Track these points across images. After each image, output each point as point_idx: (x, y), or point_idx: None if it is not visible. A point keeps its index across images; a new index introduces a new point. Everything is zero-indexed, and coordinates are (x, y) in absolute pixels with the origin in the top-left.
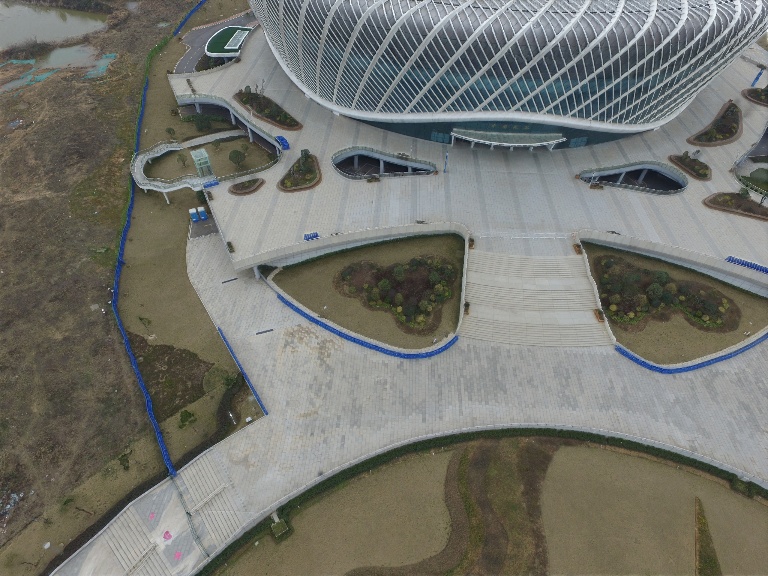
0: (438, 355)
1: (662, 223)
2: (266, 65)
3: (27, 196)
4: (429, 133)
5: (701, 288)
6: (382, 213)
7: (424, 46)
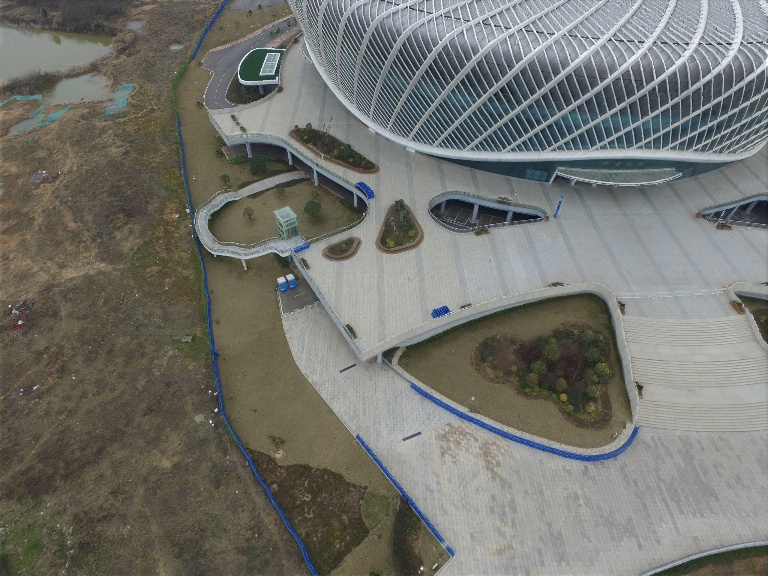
0: (623, 453)
1: None
2: (313, 94)
3: (78, 271)
4: (524, 171)
5: None
6: (507, 274)
7: (553, 85)
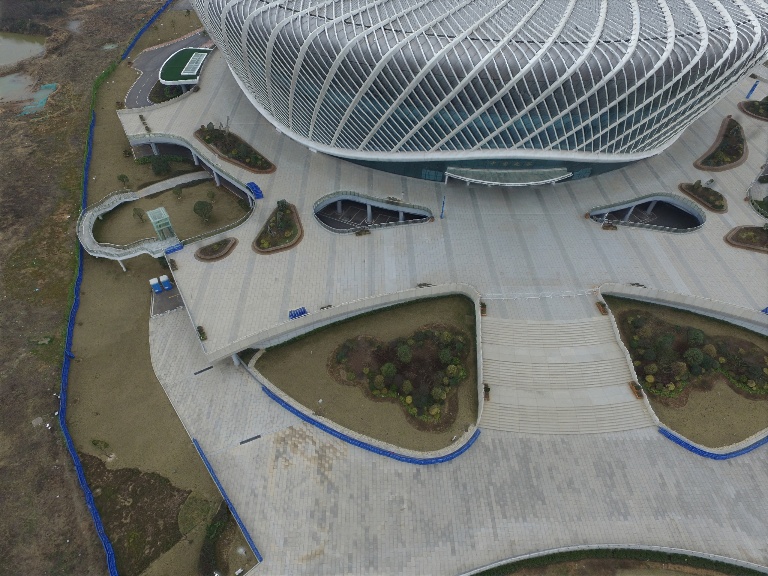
0: (460, 457)
1: (687, 268)
2: (229, 93)
3: None
4: (419, 171)
5: (739, 344)
6: (377, 275)
7: (416, 84)
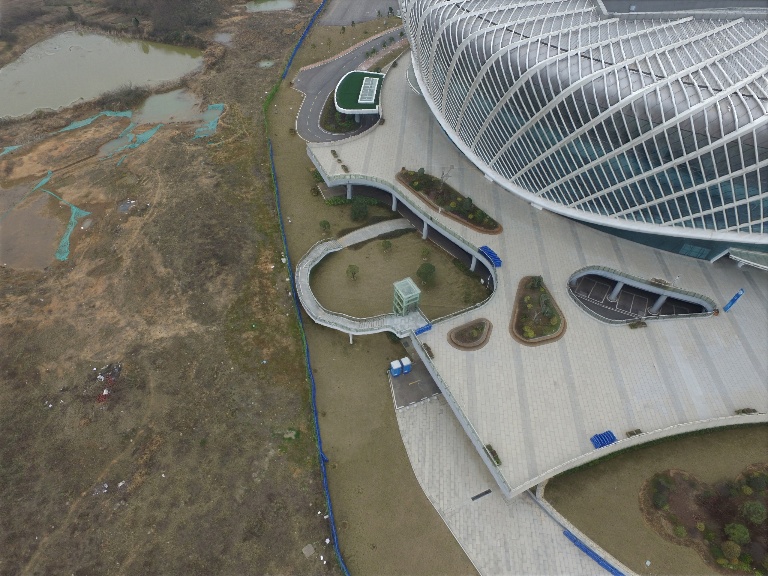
0: None
1: None
2: (418, 129)
3: (167, 330)
4: (680, 245)
5: None
6: (678, 388)
7: None
